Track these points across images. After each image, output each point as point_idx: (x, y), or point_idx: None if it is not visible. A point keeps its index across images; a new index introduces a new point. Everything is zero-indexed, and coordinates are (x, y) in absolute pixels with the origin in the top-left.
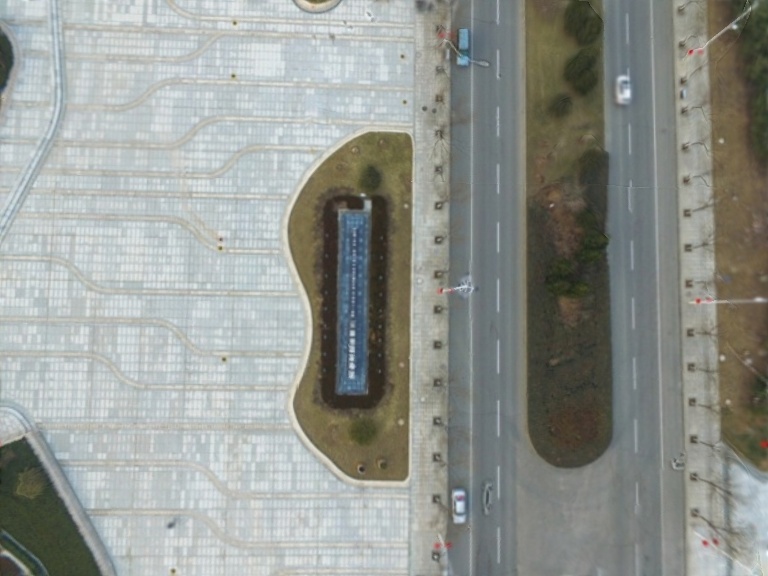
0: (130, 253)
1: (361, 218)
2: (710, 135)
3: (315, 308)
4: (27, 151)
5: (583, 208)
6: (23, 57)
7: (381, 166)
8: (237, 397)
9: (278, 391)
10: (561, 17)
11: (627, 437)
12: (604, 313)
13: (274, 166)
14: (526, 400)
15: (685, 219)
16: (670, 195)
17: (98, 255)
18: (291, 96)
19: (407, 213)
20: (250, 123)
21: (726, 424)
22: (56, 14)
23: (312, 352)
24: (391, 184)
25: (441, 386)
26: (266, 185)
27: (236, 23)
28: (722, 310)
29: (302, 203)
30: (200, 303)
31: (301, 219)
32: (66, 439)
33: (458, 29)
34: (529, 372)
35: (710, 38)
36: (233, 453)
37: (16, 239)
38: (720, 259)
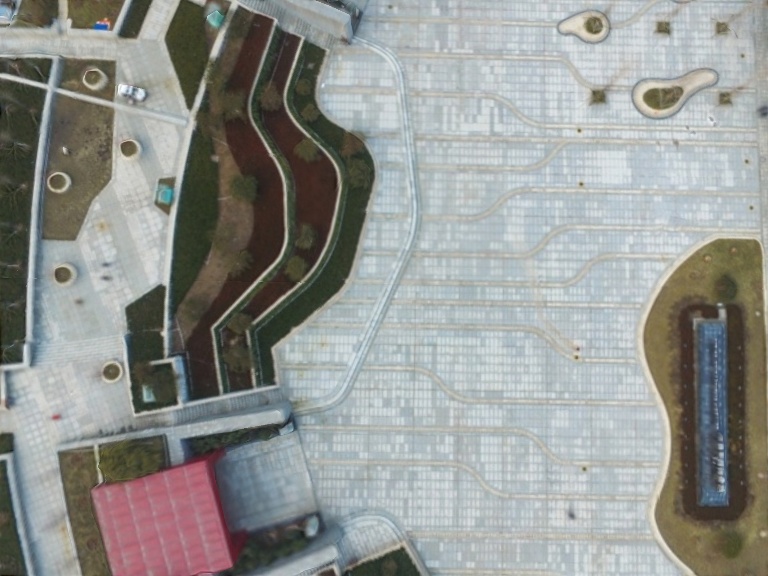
0: (489, 363)
1: (719, 328)
2: None
3: (674, 418)
4: (389, 262)
5: None
6: (380, 169)
7: (733, 274)
8: (599, 507)
9: (638, 501)
10: None
11: None
12: None
13: (626, 275)
14: None
15: None
16: None
17: (459, 365)
18: (639, 204)
19: (760, 321)
20: (600, 231)
21: None
22: (408, 125)
23: (671, 462)
24: (744, 292)
25: None
26: (619, 294)
27: (580, 130)
28: None
29: (657, 312)
30: (559, 412)
31: (656, 328)
32: (436, 547)
33: None
34: None
35: None
36: (597, 563)
37: (381, 349)
38: None
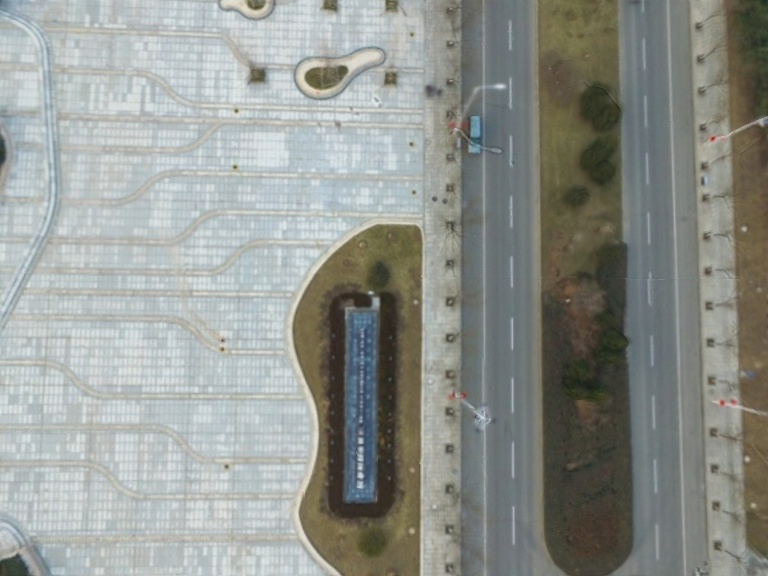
0: (128, 356)
1: (369, 317)
2: (733, 223)
3: (321, 412)
4: (20, 250)
5: (601, 306)
6: (16, 150)
7: (390, 261)
8: (240, 506)
9: (283, 499)
10: (577, 102)
11: (648, 544)
12: (623, 414)
13: (278, 262)
14: (542, 506)
15: (707, 313)
16: (691, 287)
17: (95, 358)
18: (295, 188)
19: (417, 310)
20: (253, 217)
21: (752, 530)
22: (50, 104)
23: (318, 458)
24: (400, 280)
25: (453, 493)
26: (270, 282)
27: (238, 111)
28: (749, 419)
29: (307, 301)
30: (201, 407)
31: (306, 318)
32: (62, 553)
33: (469, 116)
34: (545, 477)
35: (732, 122)
36: (236, 566)
37: (9, 342)
38: (744, 355)
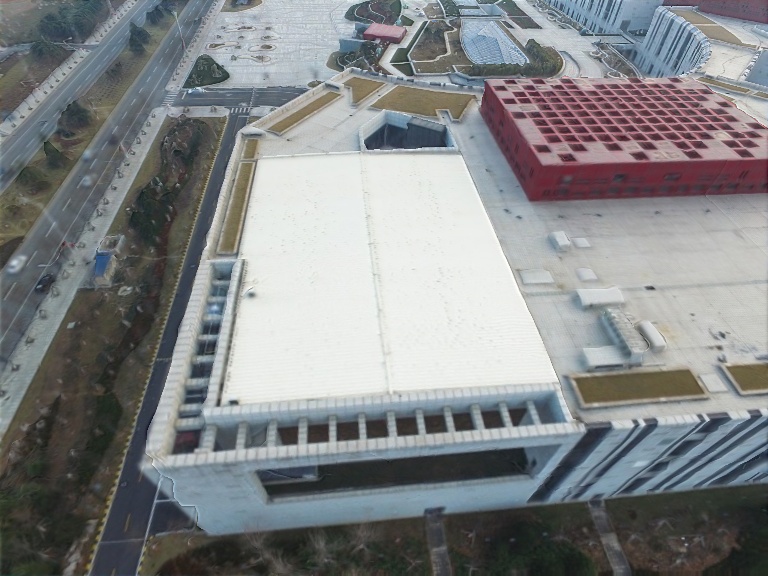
0: (308, 1)
1: None
2: None
3: None
4: None
5: None
6: None
7: None
8: None
9: None
10: None
11: None
12: None
13: None
14: None
15: (134, 3)
16: (136, 6)
17: None
18: None
19: (225, 4)
20: None
21: None
22: None
23: None
24: None
25: None
26: None
27: None
28: None
29: None
30: None
31: None
32: None
33: (198, 20)
34: None
35: None
36: None
37: (340, 2)
38: None
